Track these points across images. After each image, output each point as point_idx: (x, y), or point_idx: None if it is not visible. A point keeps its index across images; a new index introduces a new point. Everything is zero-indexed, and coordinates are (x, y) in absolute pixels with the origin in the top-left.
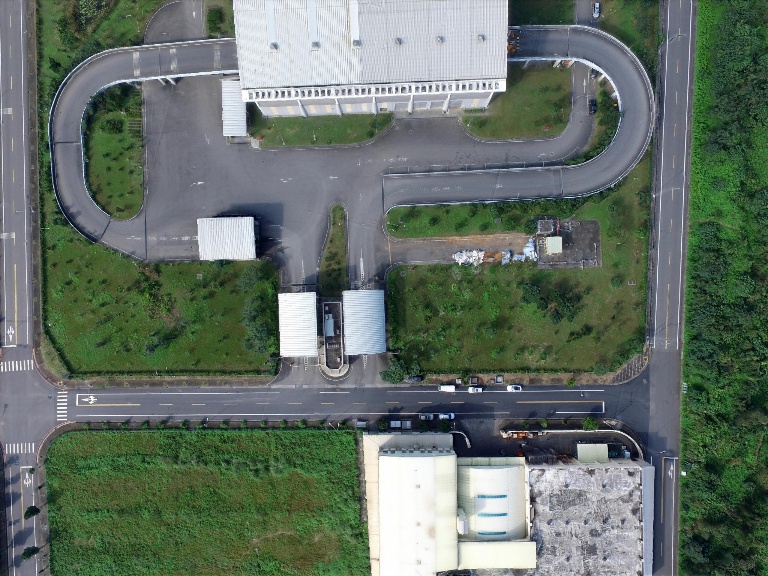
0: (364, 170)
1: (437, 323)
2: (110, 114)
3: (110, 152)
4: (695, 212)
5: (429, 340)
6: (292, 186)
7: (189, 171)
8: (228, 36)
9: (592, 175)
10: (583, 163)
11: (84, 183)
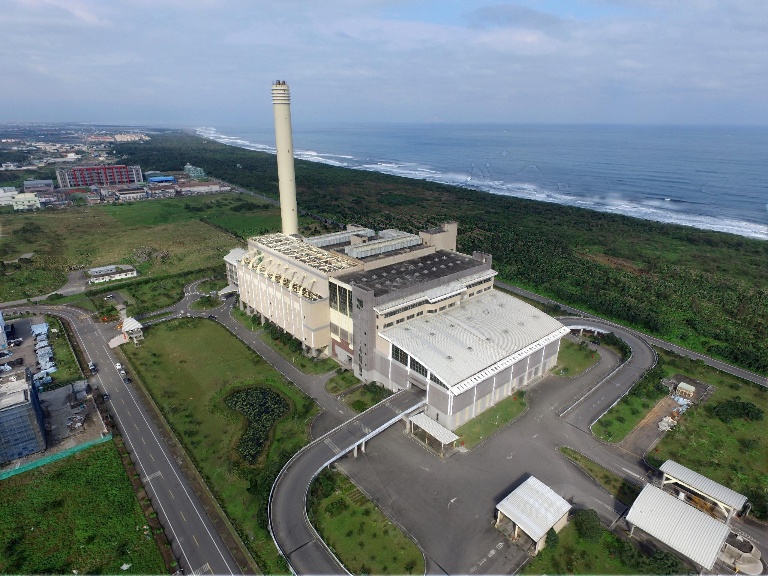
0: (546, 422)
1: (725, 470)
2: (326, 501)
3: (350, 530)
4: (697, 349)
5: (743, 484)
6: (519, 457)
7: (435, 498)
8: (389, 396)
9: (643, 357)
10: (631, 355)
11: (348, 573)
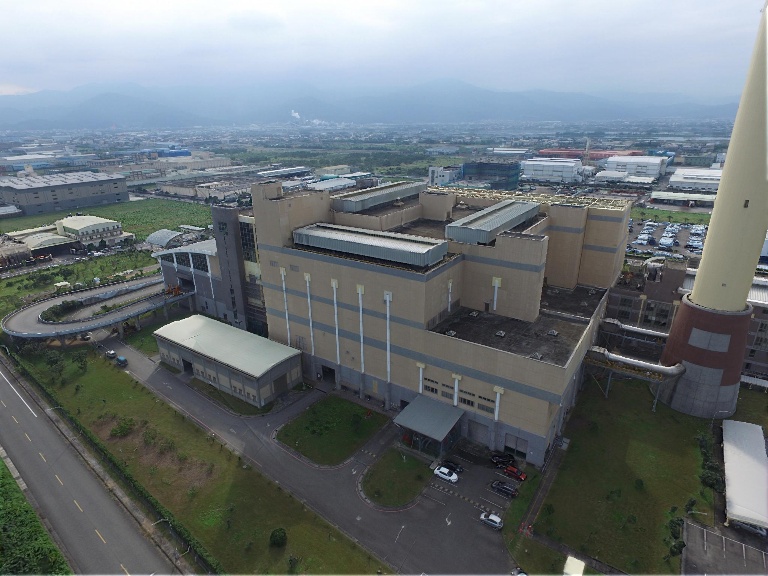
0: None
1: None
2: None
3: None
4: None
5: None
6: None
7: None
8: None
9: None
10: None
11: None
